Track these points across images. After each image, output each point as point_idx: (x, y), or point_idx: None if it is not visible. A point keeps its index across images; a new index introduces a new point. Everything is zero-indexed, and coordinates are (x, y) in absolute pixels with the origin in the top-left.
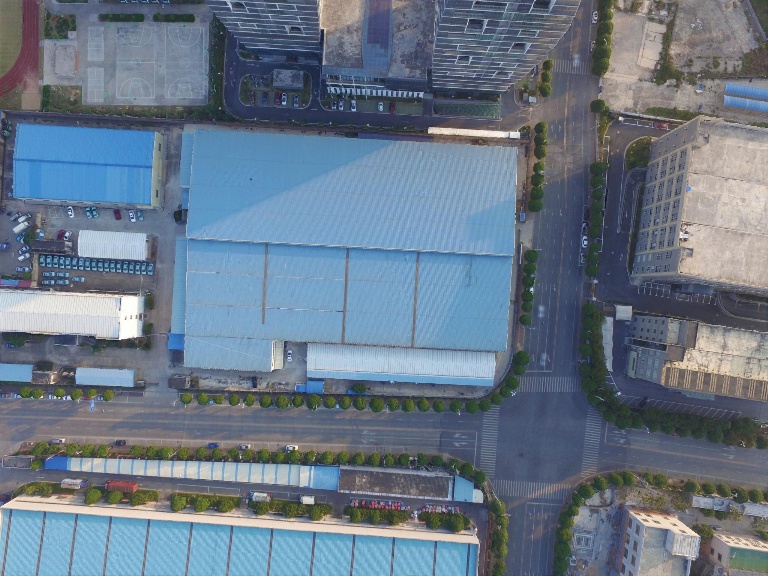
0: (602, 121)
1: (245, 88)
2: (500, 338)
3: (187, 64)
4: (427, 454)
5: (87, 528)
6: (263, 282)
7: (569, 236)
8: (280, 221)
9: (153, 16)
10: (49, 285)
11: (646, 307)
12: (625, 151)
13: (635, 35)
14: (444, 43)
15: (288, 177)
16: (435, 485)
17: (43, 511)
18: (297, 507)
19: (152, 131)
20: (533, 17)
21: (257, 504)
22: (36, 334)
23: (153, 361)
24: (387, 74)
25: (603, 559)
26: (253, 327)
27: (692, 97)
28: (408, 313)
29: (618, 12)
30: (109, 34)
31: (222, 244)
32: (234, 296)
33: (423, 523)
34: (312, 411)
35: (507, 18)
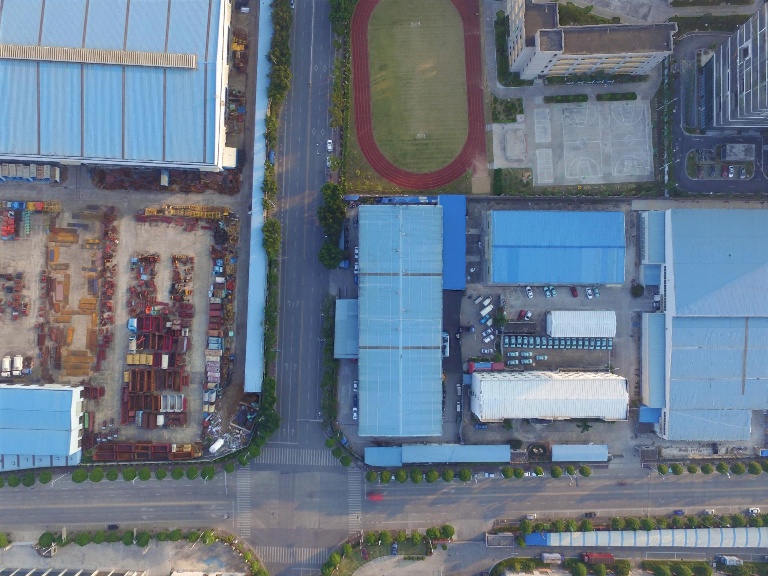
0: None
1: (692, 162)
2: None
3: (632, 141)
4: None
5: None
6: (743, 354)
7: None
8: (762, 295)
9: (596, 96)
10: (514, 365)
11: None
12: None
13: None
14: None
15: (764, 251)
16: None
17: None
18: None
19: None
20: None
21: (738, 569)
22: None
23: (615, 433)
24: None
25: None
26: (733, 398)
27: None
28: None
29: None
30: (555, 115)
31: (705, 320)
32: (715, 369)
33: None
34: None
35: None
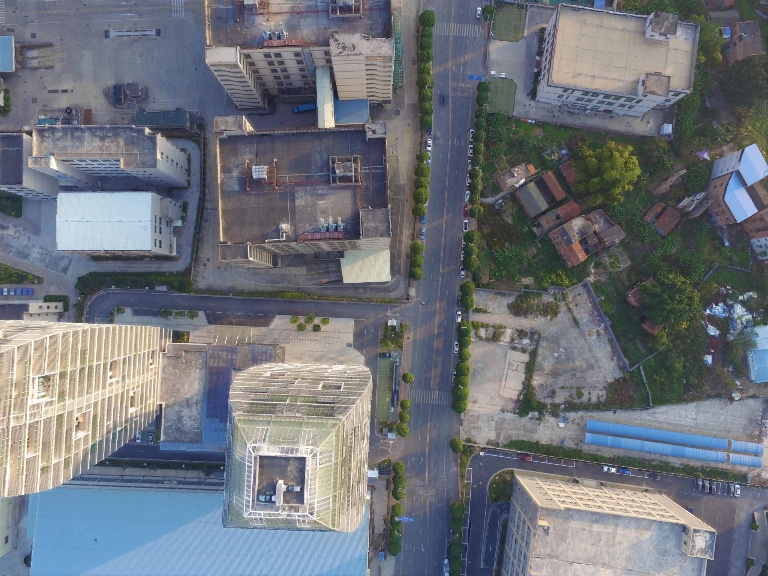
0: None
1: None
2: None
3: None
4: None
5: None
6: None
7: (432, 571)
8: None
9: None
10: None
11: None
12: (488, 483)
13: (497, 364)
14: None
15: (134, 537)
16: None
17: None
18: None
19: None
20: None
21: None
22: None
23: None
24: None
25: None
26: None
27: (555, 430)
28: None
29: (480, 341)
30: None
31: None
32: None
33: None
34: None
35: None
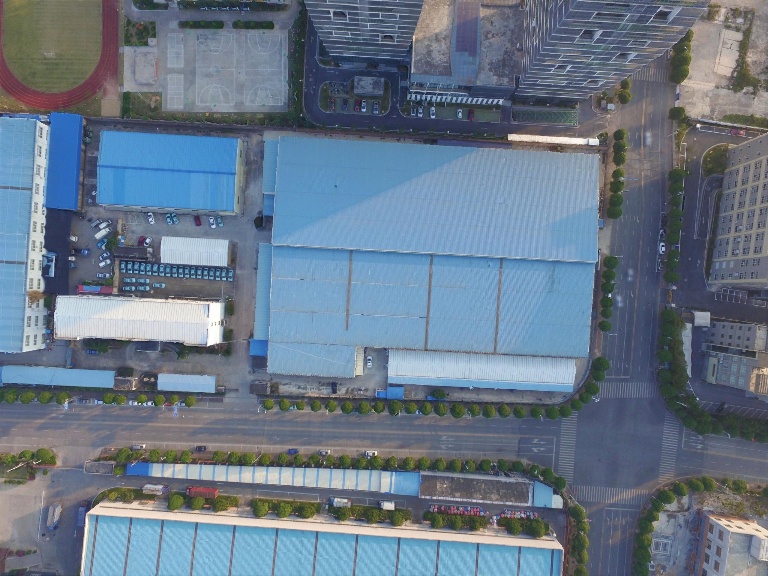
0: (680, 128)
1: (325, 95)
2: (582, 344)
3: (266, 71)
4: (506, 460)
5: (173, 534)
6: (347, 288)
7: (646, 242)
8: (365, 228)
9: (233, 23)
10: (130, 291)
11: (723, 313)
12: (702, 158)
13: (712, 43)
14: (549, 52)
15: (372, 184)
16: (515, 491)
17: (130, 517)
18: (379, 513)
19: (235, 138)
20: (649, 28)
21: (339, 510)
22: (117, 340)
23: (233, 367)
24: (475, 82)
25: (681, 564)
26: (337, 333)
27: None
28: (491, 319)
29: None
30: (189, 41)
31: (307, 251)
32: (318, 302)
33: (502, 528)
34: (391, 417)
35: (623, 29)
